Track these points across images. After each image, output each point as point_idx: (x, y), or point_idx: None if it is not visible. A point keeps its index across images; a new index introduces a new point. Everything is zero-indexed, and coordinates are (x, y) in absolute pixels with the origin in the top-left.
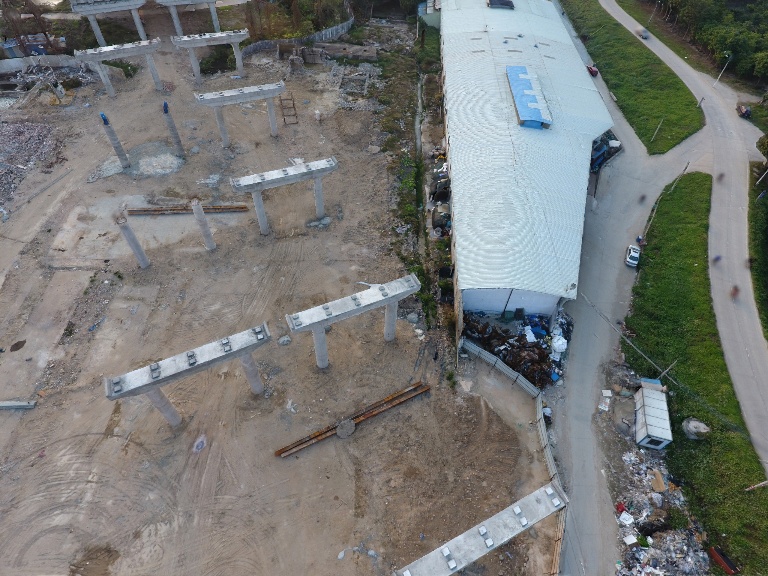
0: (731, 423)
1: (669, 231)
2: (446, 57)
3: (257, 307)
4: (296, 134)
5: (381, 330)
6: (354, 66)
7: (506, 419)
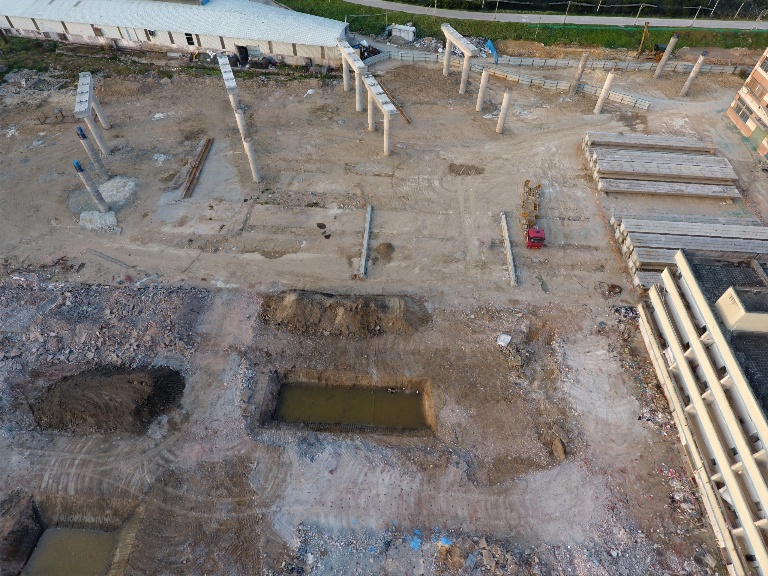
0: (410, 15)
1: (302, 3)
2: (68, 20)
3: (313, 132)
4: (115, 116)
5: (342, 92)
6: (4, 83)
7: (398, 66)
